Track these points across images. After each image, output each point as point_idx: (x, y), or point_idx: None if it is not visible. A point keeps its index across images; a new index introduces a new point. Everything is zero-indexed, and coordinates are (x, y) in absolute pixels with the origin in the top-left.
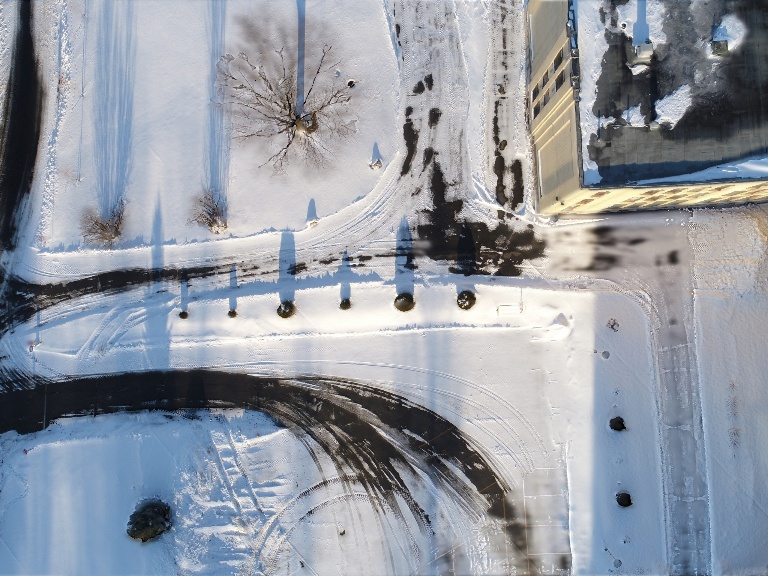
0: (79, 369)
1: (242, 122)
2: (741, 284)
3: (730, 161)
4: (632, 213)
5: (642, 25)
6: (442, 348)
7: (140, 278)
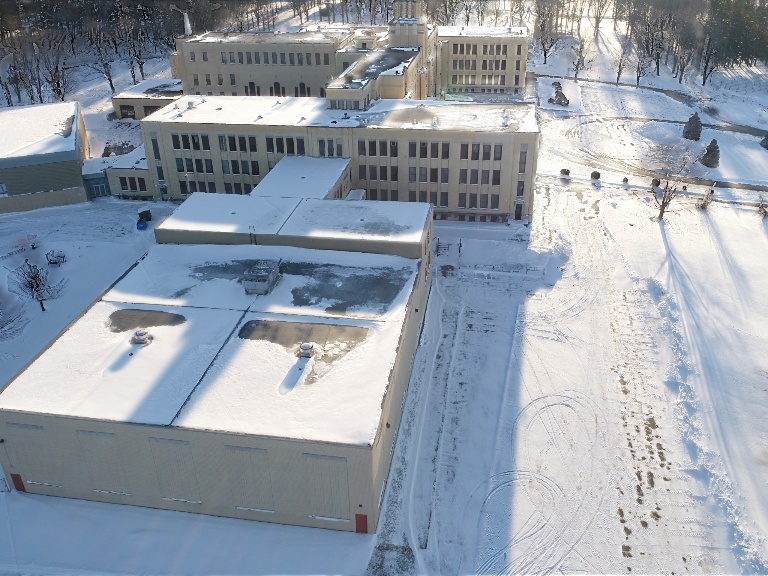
0: (765, 193)
1: (696, 226)
2: None
3: (475, 104)
4: None
5: (507, 120)
6: (576, 172)
7: (741, 203)
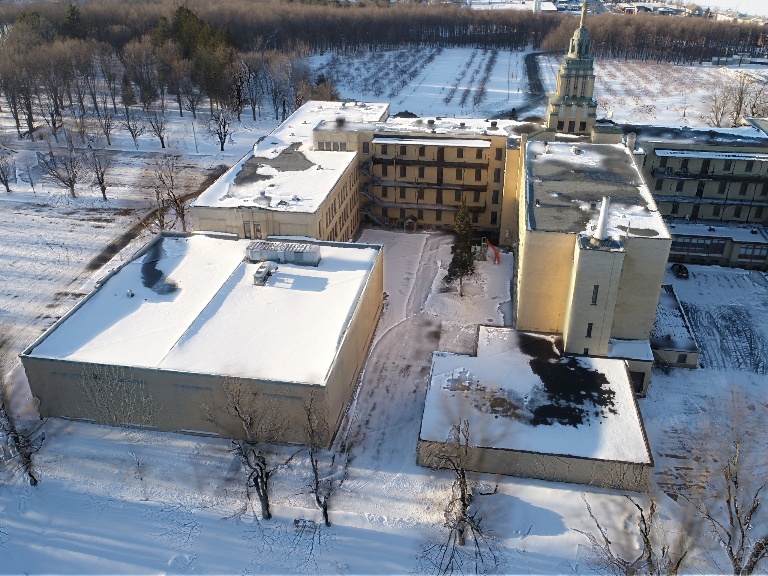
0: None
1: None
2: None
3: (765, 131)
4: None
5: None
6: None
7: None
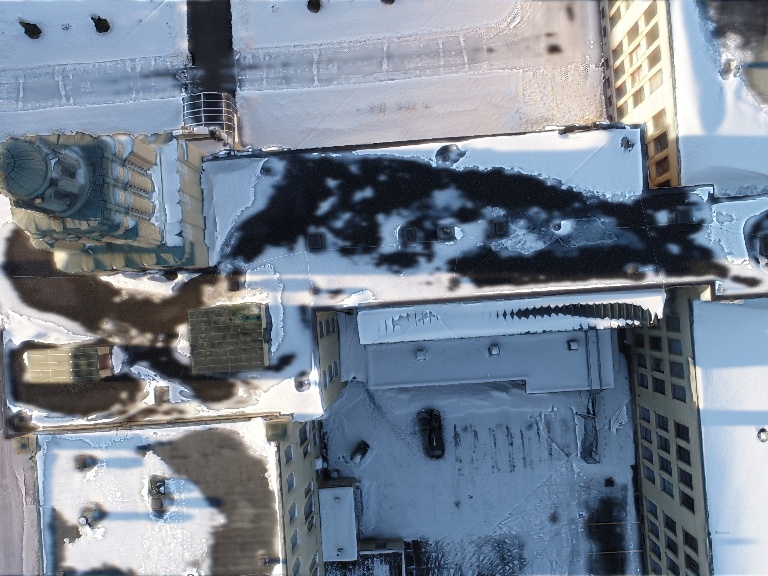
0: None
1: None
2: (530, 109)
3: None
4: (598, 7)
5: None
6: None
7: None
